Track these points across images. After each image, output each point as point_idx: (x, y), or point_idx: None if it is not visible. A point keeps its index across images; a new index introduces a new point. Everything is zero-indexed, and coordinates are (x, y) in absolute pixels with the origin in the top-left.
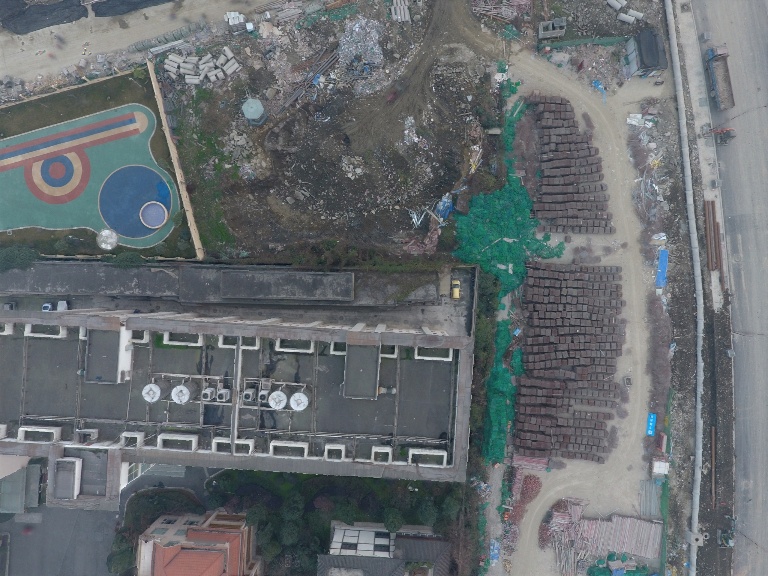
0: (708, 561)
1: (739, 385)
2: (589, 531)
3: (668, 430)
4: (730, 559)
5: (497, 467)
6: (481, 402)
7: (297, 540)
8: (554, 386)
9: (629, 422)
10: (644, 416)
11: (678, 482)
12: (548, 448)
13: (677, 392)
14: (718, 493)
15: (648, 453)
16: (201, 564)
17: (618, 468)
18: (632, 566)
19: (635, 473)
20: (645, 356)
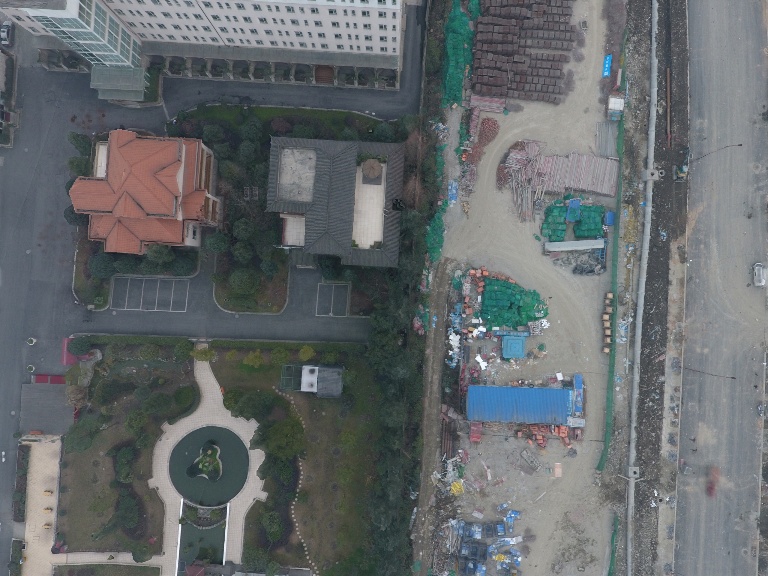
0: (664, 197)
1: (693, 27)
2: (546, 166)
3: (623, 67)
4: (685, 195)
5: (455, 108)
6: (438, 35)
7: (254, 156)
8: (510, 23)
9: (585, 66)
10: (600, 60)
11: (634, 123)
12: (504, 83)
13: (632, 35)
14: (673, 131)
15: (604, 95)
16: (155, 147)
17: (575, 111)
18: (589, 203)
19: (592, 115)
20: (601, 2)
